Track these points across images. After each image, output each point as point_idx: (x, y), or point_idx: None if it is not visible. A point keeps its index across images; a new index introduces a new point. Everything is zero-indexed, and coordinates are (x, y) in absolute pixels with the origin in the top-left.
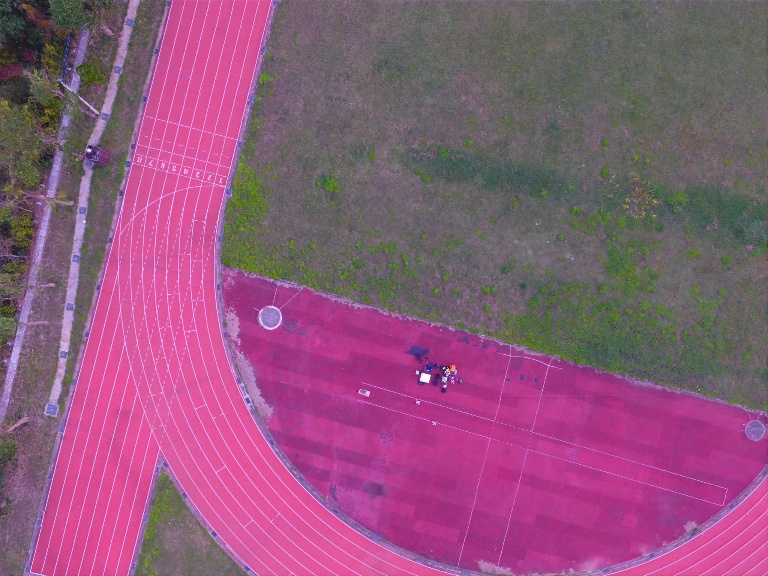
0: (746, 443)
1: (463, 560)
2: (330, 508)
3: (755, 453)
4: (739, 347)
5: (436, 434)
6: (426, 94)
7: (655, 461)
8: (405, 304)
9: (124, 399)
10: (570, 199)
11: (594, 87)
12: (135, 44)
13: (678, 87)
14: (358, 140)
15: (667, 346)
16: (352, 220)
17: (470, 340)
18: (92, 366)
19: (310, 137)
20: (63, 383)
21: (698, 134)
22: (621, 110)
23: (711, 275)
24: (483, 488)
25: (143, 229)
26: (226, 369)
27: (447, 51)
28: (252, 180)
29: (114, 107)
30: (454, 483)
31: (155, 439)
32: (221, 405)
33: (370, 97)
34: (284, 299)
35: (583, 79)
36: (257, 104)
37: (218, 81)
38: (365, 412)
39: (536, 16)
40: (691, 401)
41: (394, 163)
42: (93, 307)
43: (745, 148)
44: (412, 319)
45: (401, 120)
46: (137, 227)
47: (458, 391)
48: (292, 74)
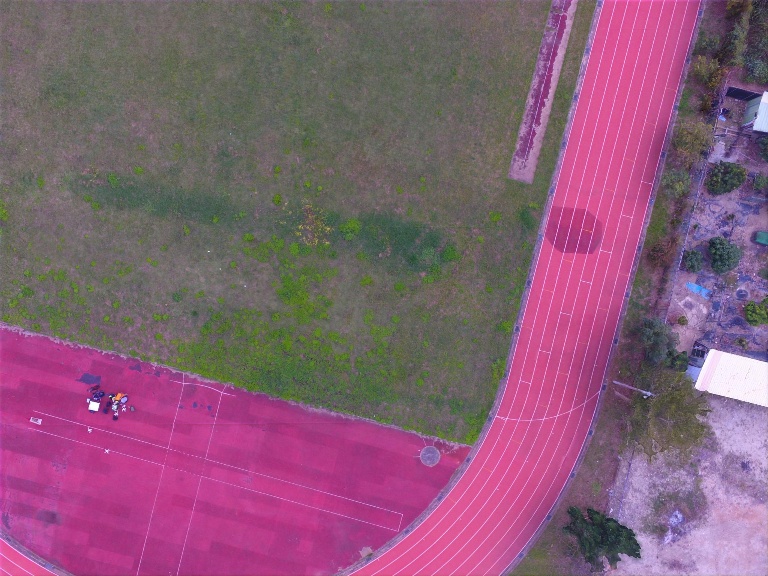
0: (421, 469)
1: None
2: (3, 536)
3: (430, 479)
4: (413, 374)
5: (109, 462)
6: (95, 121)
7: (330, 487)
8: (76, 332)
9: None
10: (242, 226)
11: (265, 114)
12: None
13: (350, 114)
14: (26, 167)
15: (341, 373)
16: (21, 248)
17: (142, 368)
18: None
19: None
20: None
21: (371, 161)
22: (293, 137)
23: (385, 302)
24: (157, 515)
25: None
26: None
27: (115, 78)
28: None
29: None
30: (128, 510)
31: None
32: None
33: (38, 124)
34: None
35: (254, 106)
36: None
37: None
38: (37, 440)
39: (205, 42)
40: (366, 427)
41: (63, 190)
42: None
43: (418, 175)
44: (83, 347)
45: (70, 147)
46: None
47: (131, 419)
48: None
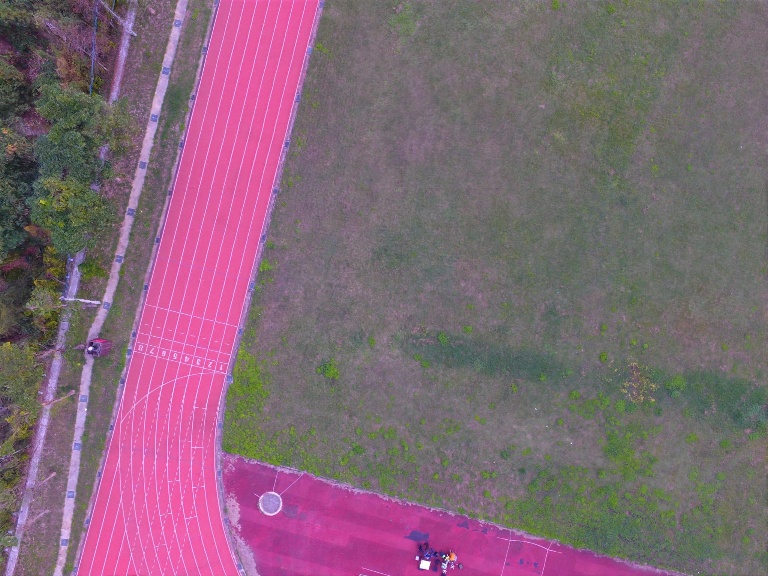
0: None
1: None
2: None
3: None
4: (738, 531)
5: None
6: (425, 281)
7: None
8: (405, 489)
9: None
10: (569, 384)
11: (592, 273)
12: (136, 234)
13: (676, 272)
14: (358, 327)
15: (666, 530)
16: (352, 406)
17: (470, 525)
18: (93, 554)
19: (310, 324)
20: (64, 571)
21: (696, 319)
22: (619, 295)
23: (709, 459)
24: None
25: (144, 417)
26: (226, 555)
27: (446, 238)
28: (252, 367)
29: (115, 296)
30: None
31: None
32: None
33: (370, 284)
34: (284, 485)
35: (581, 265)
36: (257, 292)
37: (219, 269)
38: None
39: (534, 203)
40: None
41: (394, 349)
42: (94, 494)
43: (742, 333)
44: (412, 504)
45: (401, 306)
46: (138, 415)
47: (458, 575)
48: (292, 262)
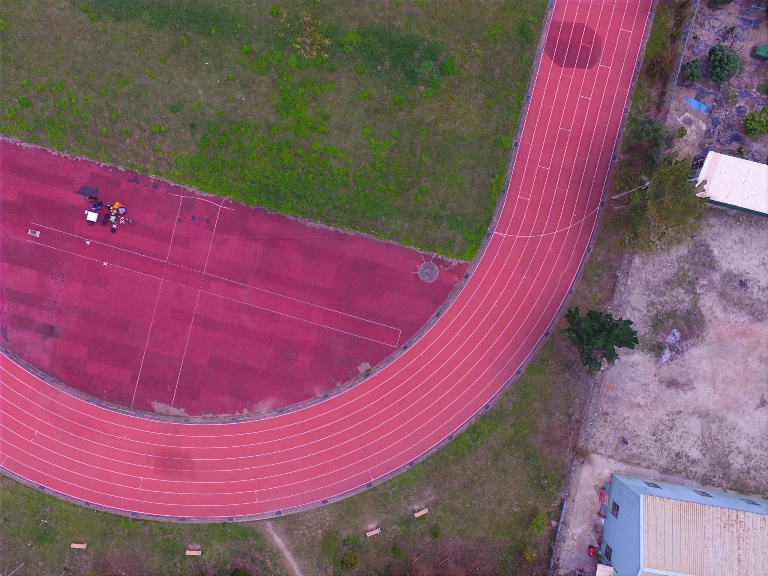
0: (420, 285)
1: (137, 401)
2: (2, 349)
3: (429, 295)
4: (411, 188)
5: (108, 275)
6: None
7: (329, 302)
8: (74, 144)
9: None
10: (240, 38)
11: None
12: None
13: None
14: None
15: (339, 187)
16: (18, 58)
17: (140, 180)
18: None
19: None
20: None
21: None
22: None
23: (383, 116)
24: (156, 329)
25: None
26: None
27: None
28: None
29: None
30: (126, 324)
31: None
32: None
33: None
34: None
35: None
36: None
37: None
38: (35, 252)
39: None
40: (364, 242)
41: (60, 0)
42: None
43: None
44: (81, 159)
45: None
46: None
47: (129, 232)
48: None
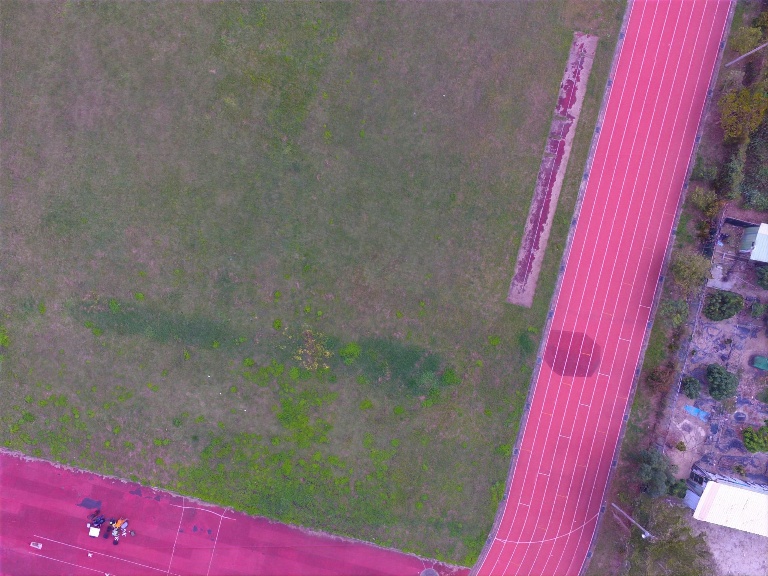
0: None
1: None
2: None
3: None
4: (412, 497)
5: None
6: (96, 247)
7: None
8: (77, 457)
9: None
10: (242, 351)
11: (266, 240)
12: None
13: (350, 239)
14: (27, 294)
15: (340, 496)
16: (22, 373)
17: (142, 492)
18: None
19: None
20: None
21: (371, 286)
22: (293, 262)
23: (384, 426)
24: None
25: None
26: None
27: (116, 204)
28: None
29: None
30: None
31: None
32: None
33: (39, 250)
34: None
35: (255, 232)
36: None
37: None
38: (37, 564)
39: (206, 169)
40: (365, 550)
41: (64, 316)
42: None
43: (417, 300)
44: (84, 472)
45: (71, 273)
46: None
47: (131, 543)
48: None
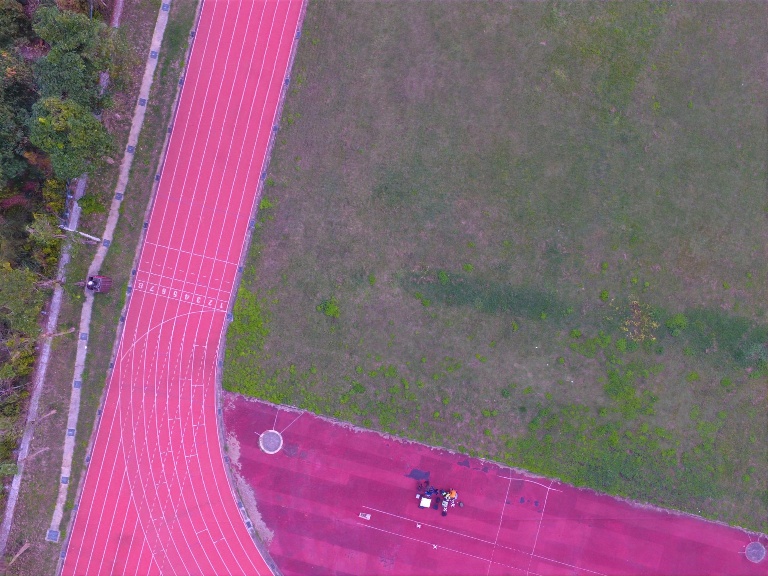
0: (746, 565)
1: None
2: None
3: (755, 575)
4: (739, 469)
5: (437, 557)
6: (426, 219)
7: None
8: (405, 428)
9: (125, 524)
10: (570, 322)
11: (593, 211)
12: (136, 171)
13: (677, 210)
14: (358, 265)
15: (667, 468)
16: (352, 344)
17: (470, 463)
18: (93, 491)
19: (310, 262)
20: (64, 509)
21: (697, 257)
22: (620, 233)
23: (711, 397)
24: None
25: (144, 355)
26: (227, 493)
27: (447, 176)
28: (253, 305)
29: (115, 234)
30: None
31: (156, 564)
32: (222, 529)
33: (370, 222)
34: (285, 423)
35: (582, 203)
36: (258, 230)
37: (219, 207)
38: (366, 535)
39: (535, 141)
40: (691, 523)
41: (394, 287)
42: (94, 432)
43: (744, 271)
44: (412, 442)
45: (401, 244)
46: (138, 353)
47: (458, 514)
48: (292, 200)
